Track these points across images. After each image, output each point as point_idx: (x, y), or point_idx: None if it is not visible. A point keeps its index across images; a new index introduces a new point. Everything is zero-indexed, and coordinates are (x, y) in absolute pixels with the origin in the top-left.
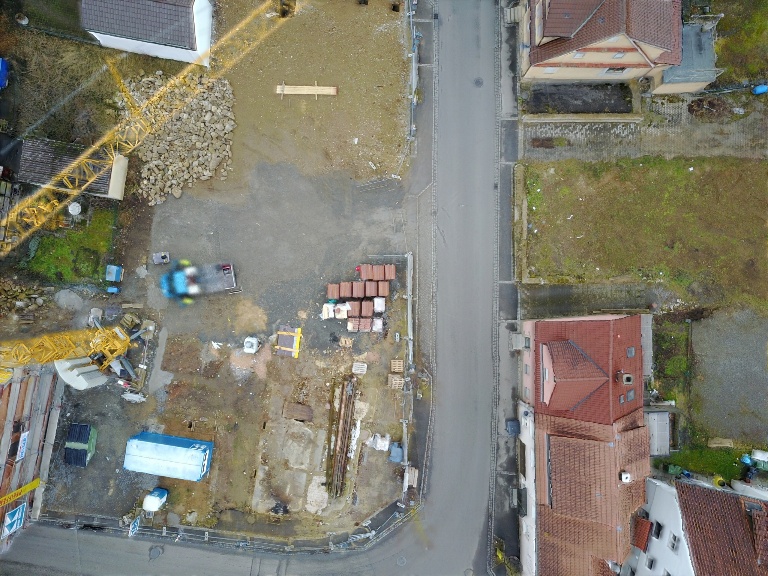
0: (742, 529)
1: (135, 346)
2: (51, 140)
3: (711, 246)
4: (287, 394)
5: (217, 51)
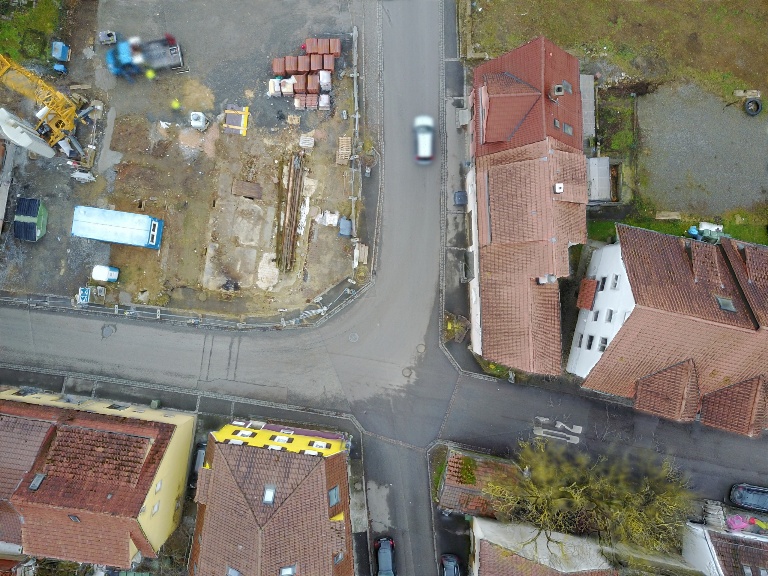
0: (681, 259)
1: (83, 125)
2: None
3: (654, 21)
4: (236, 172)
5: None
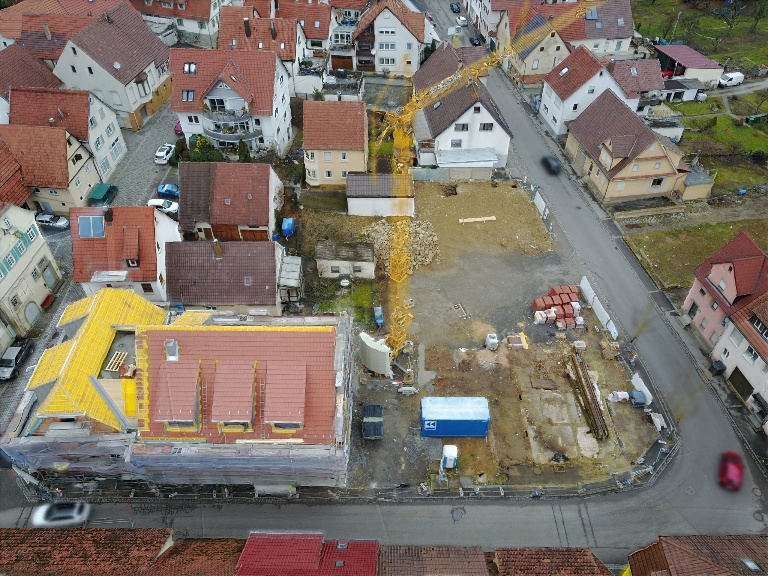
0: None
1: None
2: (333, 241)
3: None
4: (530, 373)
5: (417, 211)
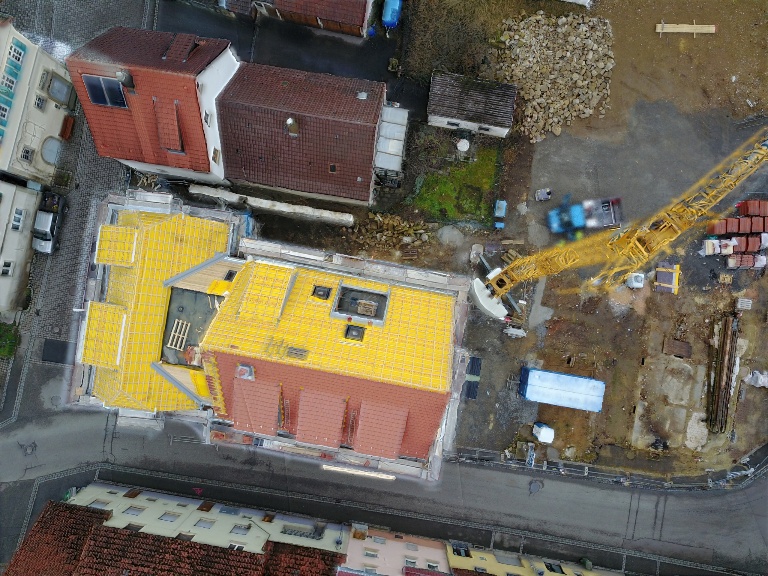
0: None
1: None
2: None
3: None
4: (667, 330)
5: None
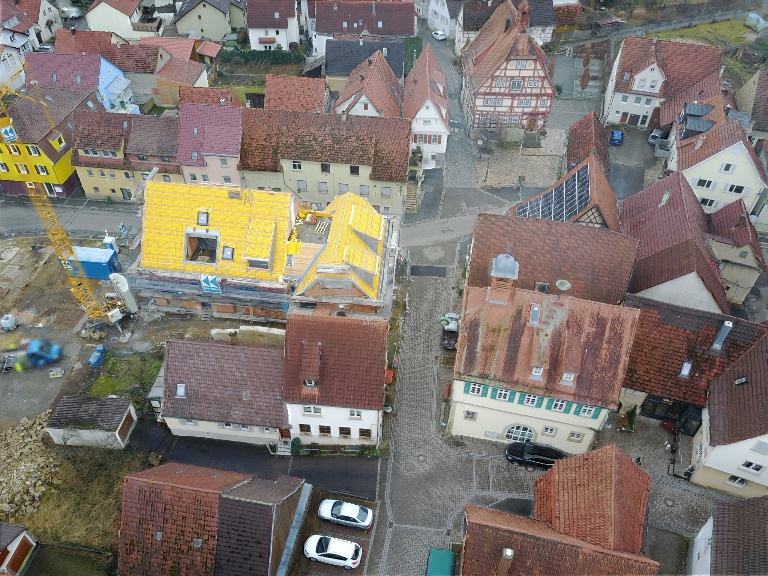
0: None
1: None
2: (95, 430)
3: None
4: (0, 301)
5: None
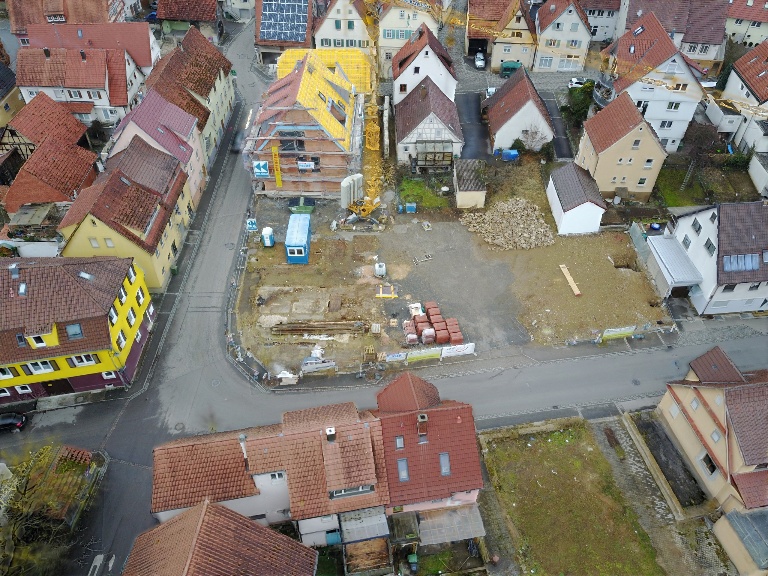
0: None
1: None
2: None
3: None
4: (348, 295)
5: (571, 237)
